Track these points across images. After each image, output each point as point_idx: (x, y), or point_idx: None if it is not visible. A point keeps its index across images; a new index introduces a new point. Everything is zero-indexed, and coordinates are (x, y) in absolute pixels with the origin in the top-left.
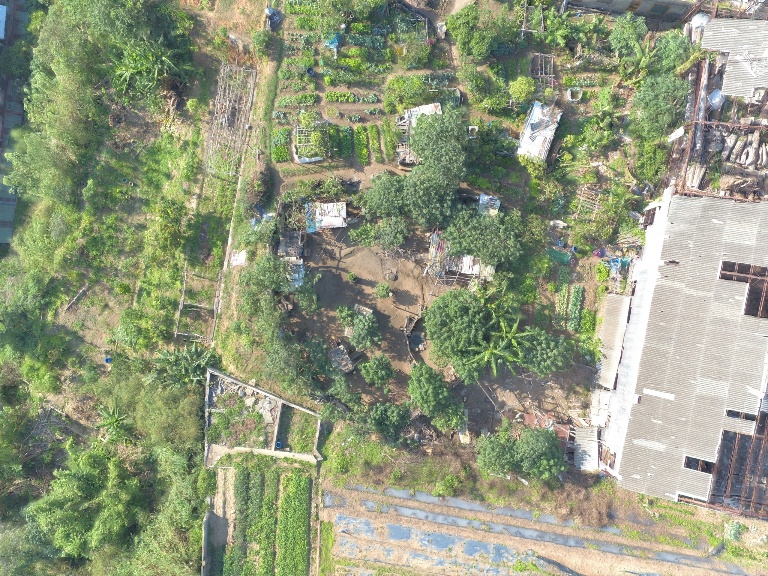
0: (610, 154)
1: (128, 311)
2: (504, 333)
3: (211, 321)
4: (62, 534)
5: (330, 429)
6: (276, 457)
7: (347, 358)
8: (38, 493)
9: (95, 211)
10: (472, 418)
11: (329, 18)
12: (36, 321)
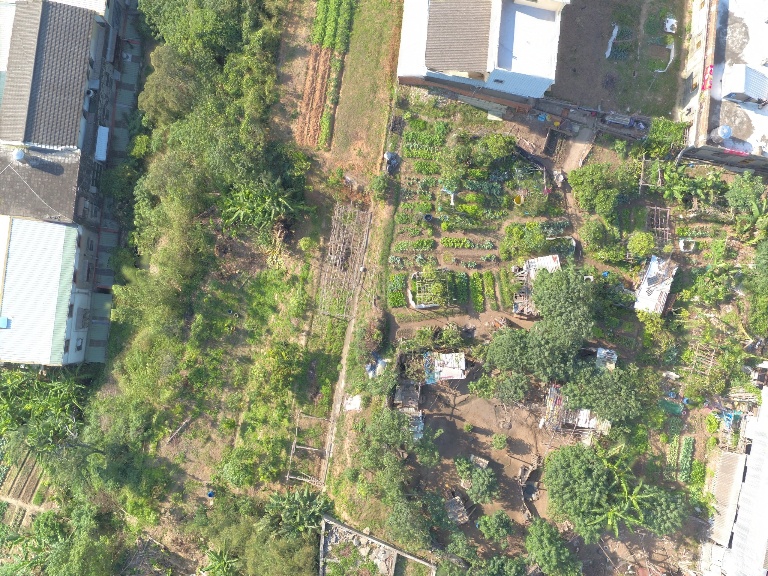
0: (722, 307)
1: (239, 452)
2: (626, 495)
3: (318, 459)
4: None
5: None
6: None
7: (463, 510)
8: None
9: (200, 342)
10: (584, 569)
11: (450, 167)
12: (137, 452)
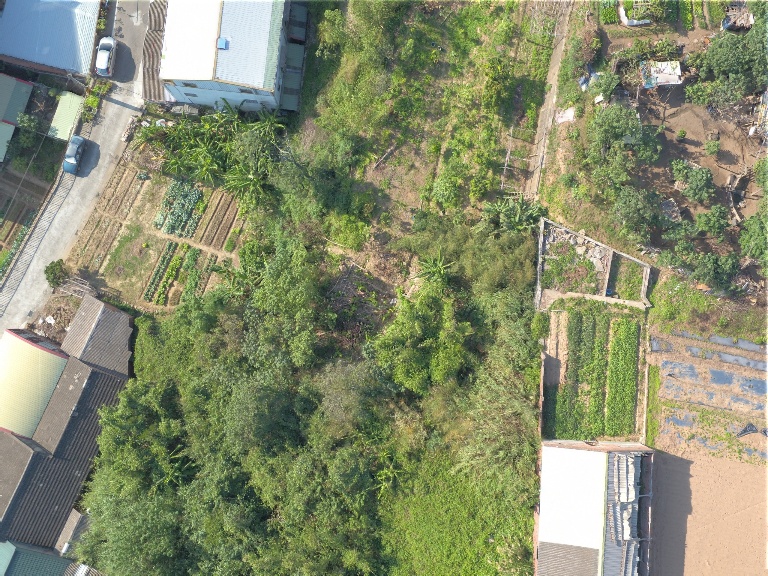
0: None
1: (454, 164)
2: None
3: (523, 180)
4: (402, 369)
5: (655, 279)
6: (607, 302)
7: (677, 210)
8: (341, 345)
9: (405, 73)
10: None
11: None
12: (344, 178)
